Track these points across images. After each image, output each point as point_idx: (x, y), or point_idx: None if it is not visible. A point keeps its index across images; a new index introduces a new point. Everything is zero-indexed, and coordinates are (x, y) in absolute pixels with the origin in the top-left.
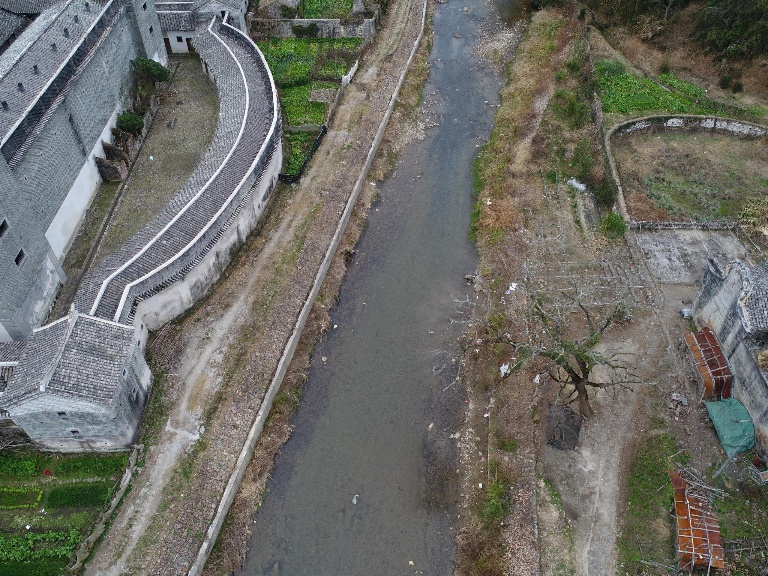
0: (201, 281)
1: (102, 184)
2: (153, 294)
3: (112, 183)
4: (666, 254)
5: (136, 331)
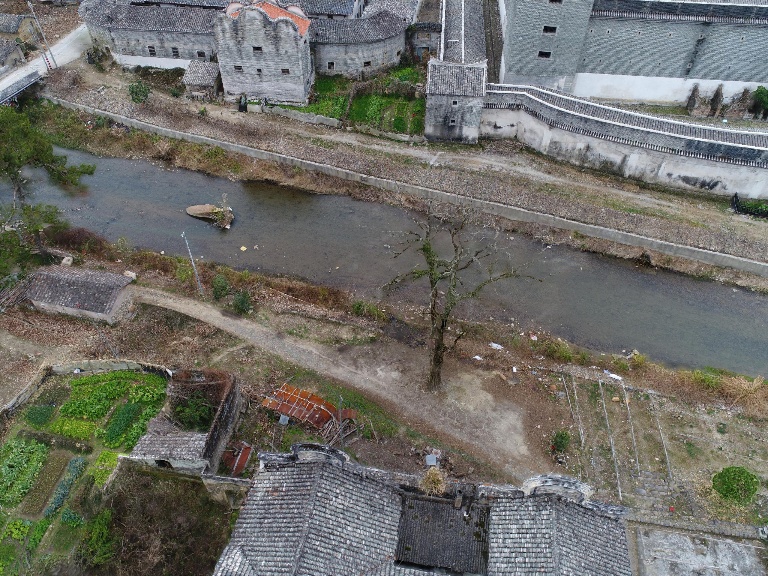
0: (562, 147)
1: (682, 107)
2: (529, 113)
3: (686, 111)
4: (711, 573)
5: (504, 119)
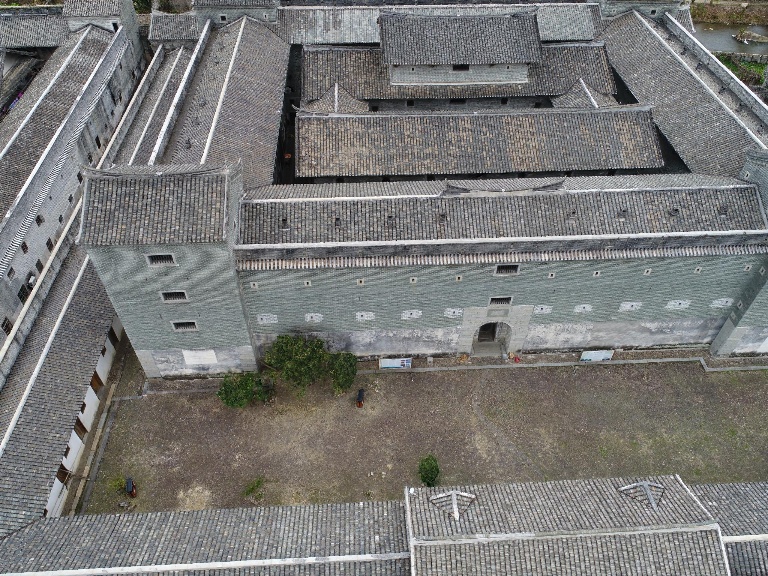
0: None
1: None
2: None
3: None
4: None
5: None
